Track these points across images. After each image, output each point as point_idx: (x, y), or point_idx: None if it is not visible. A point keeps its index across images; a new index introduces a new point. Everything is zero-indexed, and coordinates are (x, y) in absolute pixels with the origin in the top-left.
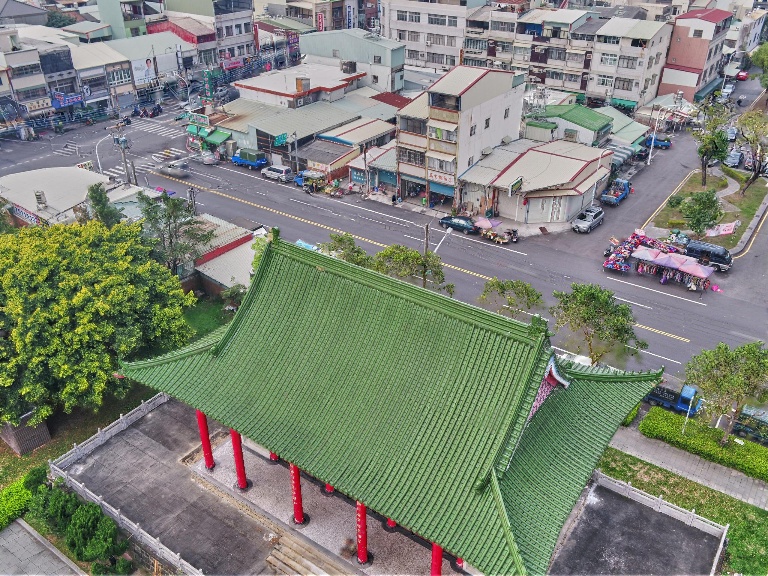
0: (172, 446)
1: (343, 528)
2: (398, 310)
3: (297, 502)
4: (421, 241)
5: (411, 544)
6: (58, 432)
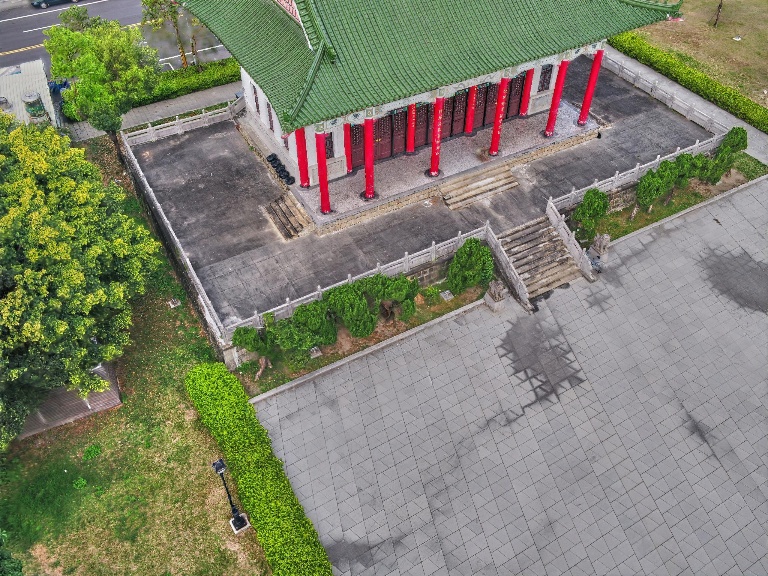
0: (258, 243)
1: (457, 155)
2: None
3: None
4: None
5: None
6: None
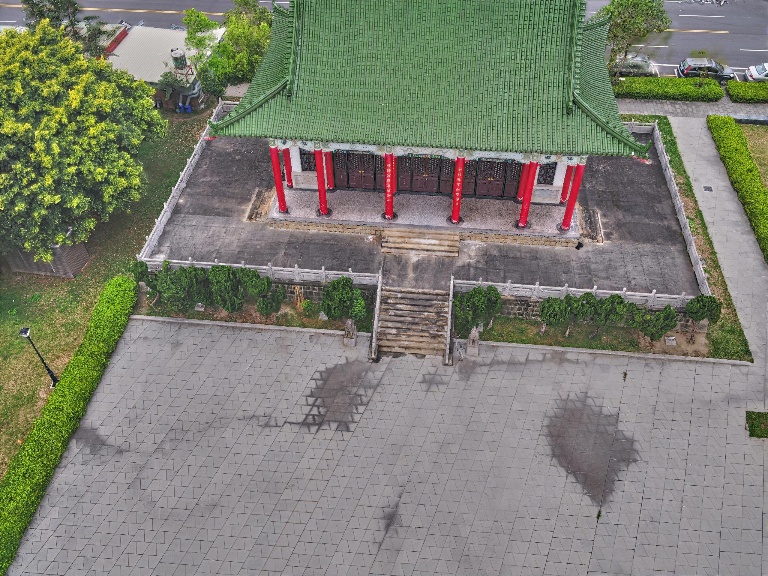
0: (228, 214)
1: (425, 209)
2: (449, 1)
3: (391, 199)
4: (280, 3)
5: (479, 201)
6: (89, 250)
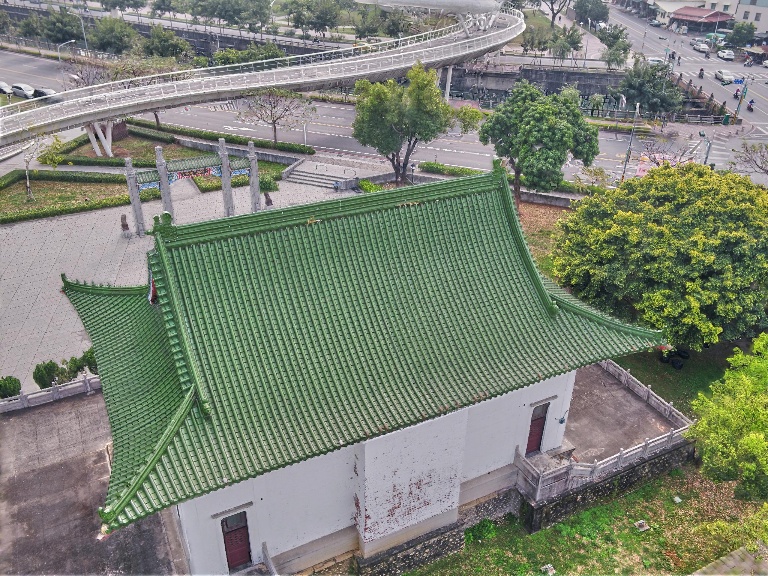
0: None
1: None
2: None
3: None
4: None
5: None
6: None
